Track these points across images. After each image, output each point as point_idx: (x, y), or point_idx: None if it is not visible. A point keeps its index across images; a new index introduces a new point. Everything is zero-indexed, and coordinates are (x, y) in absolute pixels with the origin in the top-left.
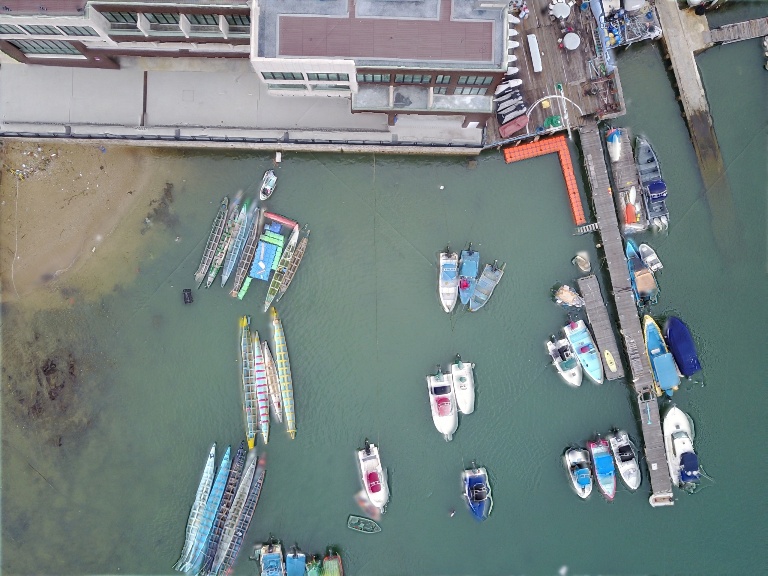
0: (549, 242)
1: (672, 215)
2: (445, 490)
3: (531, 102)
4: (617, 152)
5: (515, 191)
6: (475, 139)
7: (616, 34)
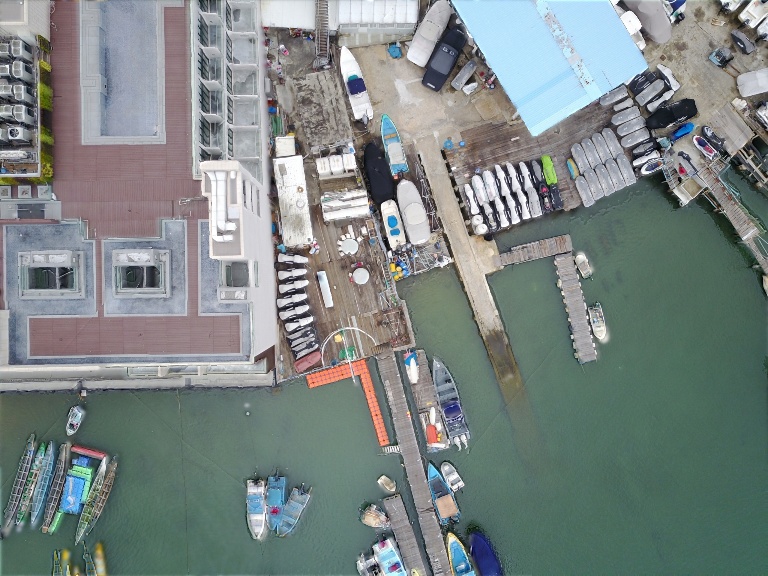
0: (356, 461)
1: (474, 431)
2: None
3: (325, 335)
4: (415, 375)
5: (321, 413)
6: (267, 379)
7: (403, 268)
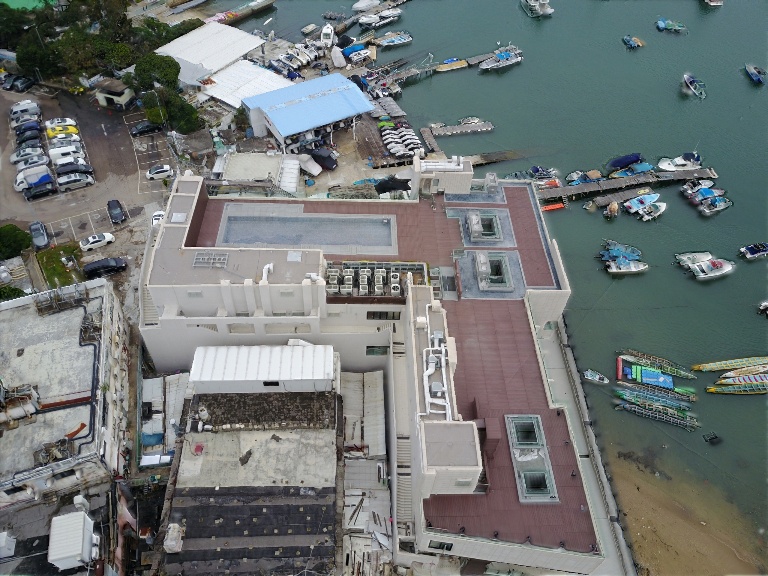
0: (578, 222)
1: None
2: (767, 270)
3: None
4: None
5: None
6: None
7: None
